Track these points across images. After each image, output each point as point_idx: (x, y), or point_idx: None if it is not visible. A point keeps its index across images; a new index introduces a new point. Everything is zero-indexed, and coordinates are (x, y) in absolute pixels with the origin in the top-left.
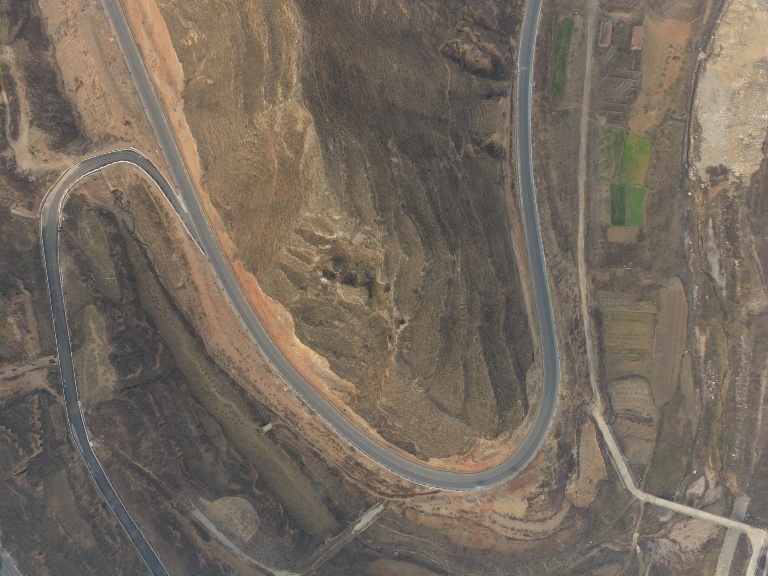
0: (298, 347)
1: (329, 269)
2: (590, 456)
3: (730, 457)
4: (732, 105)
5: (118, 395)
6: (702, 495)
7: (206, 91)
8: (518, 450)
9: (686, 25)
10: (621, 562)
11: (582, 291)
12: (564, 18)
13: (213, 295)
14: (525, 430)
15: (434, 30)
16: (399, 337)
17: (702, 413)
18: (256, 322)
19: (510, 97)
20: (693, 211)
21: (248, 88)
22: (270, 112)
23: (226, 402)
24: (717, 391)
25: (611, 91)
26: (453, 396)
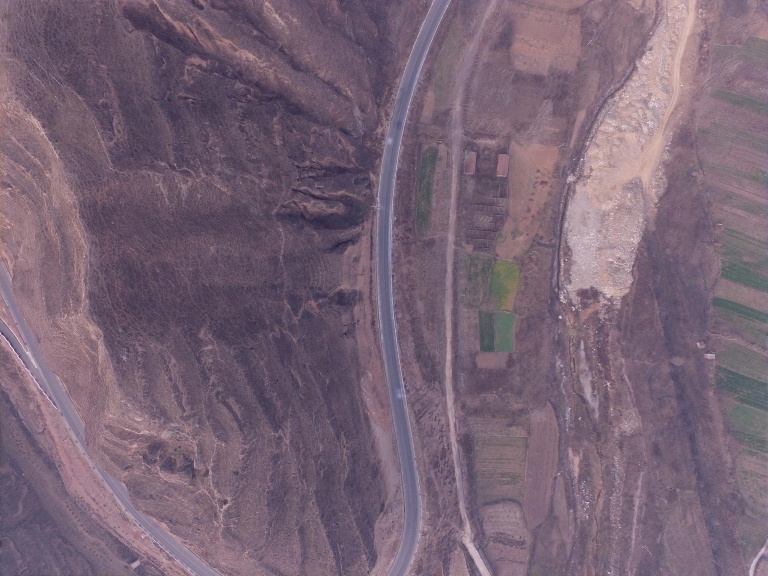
0: None
1: None
2: None
3: (606, 575)
4: (602, 227)
5: None
6: None
7: (26, 276)
8: None
9: (553, 149)
10: None
11: (450, 419)
12: (428, 147)
13: (67, 447)
14: (387, 567)
15: (265, 196)
16: (224, 515)
17: (577, 533)
18: None
19: (370, 233)
20: (564, 334)
21: (49, 291)
22: (67, 320)
23: (94, 540)
24: (591, 511)
25: (477, 219)
26: (289, 561)
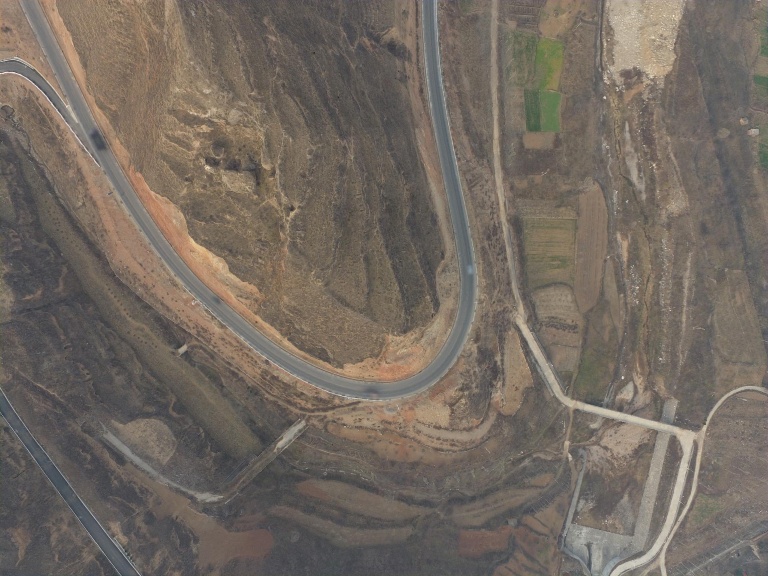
0: (198, 252)
1: (211, 155)
2: (515, 364)
3: (657, 361)
4: (643, 7)
5: (16, 316)
6: (631, 400)
7: None
8: (438, 357)
9: None
10: (553, 470)
11: (500, 198)
12: None
13: (111, 208)
14: (444, 336)
15: None
16: (290, 225)
17: (627, 318)
18: (158, 235)
19: None
20: (609, 115)
21: None
22: None
23: (138, 325)
24: (641, 296)
25: None
26: (355, 290)
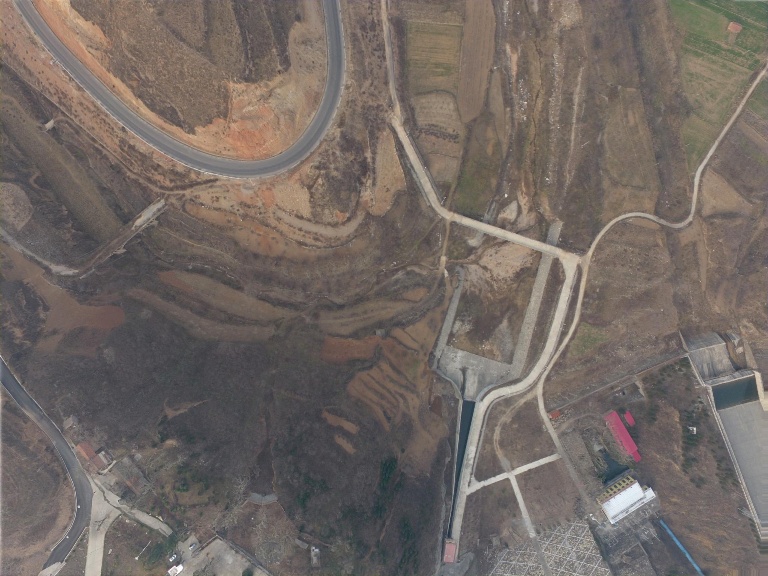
0: None
1: None
2: (388, 165)
3: (544, 182)
4: None
5: None
6: (514, 221)
7: None
8: (300, 139)
9: None
10: None
11: None
12: None
13: None
14: (308, 119)
15: None
16: None
17: (514, 134)
18: None
19: None
20: None
21: None
22: None
23: (7, 98)
24: (529, 112)
25: None
26: (192, 26)
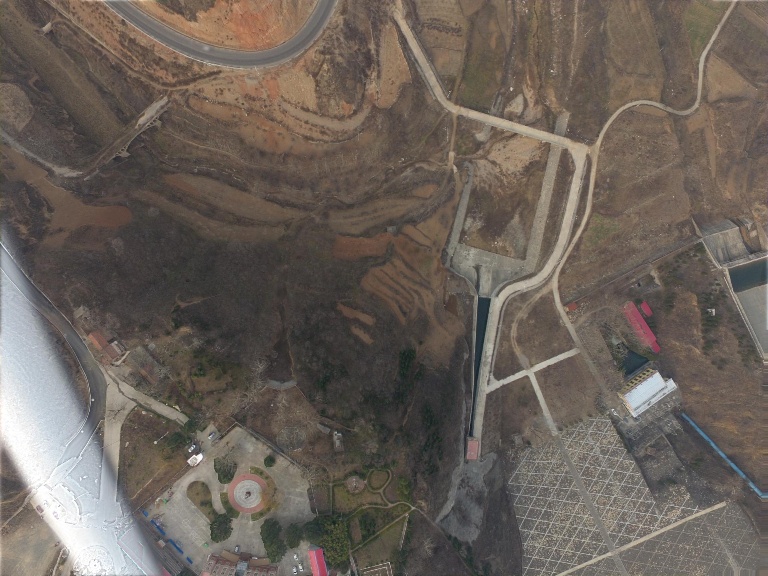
0: None
1: None
2: (392, 57)
3: (549, 74)
4: None
5: None
6: (521, 114)
7: None
8: (303, 28)
9: None
10: None
11: None
12: None
13: None
14: (310, 8)
15: None
16: None
17: (516, 28)
18: None
19: None
20: None
21: None
22: None
23: (3, 2)
24: (531, 4)
25: None
26: None
